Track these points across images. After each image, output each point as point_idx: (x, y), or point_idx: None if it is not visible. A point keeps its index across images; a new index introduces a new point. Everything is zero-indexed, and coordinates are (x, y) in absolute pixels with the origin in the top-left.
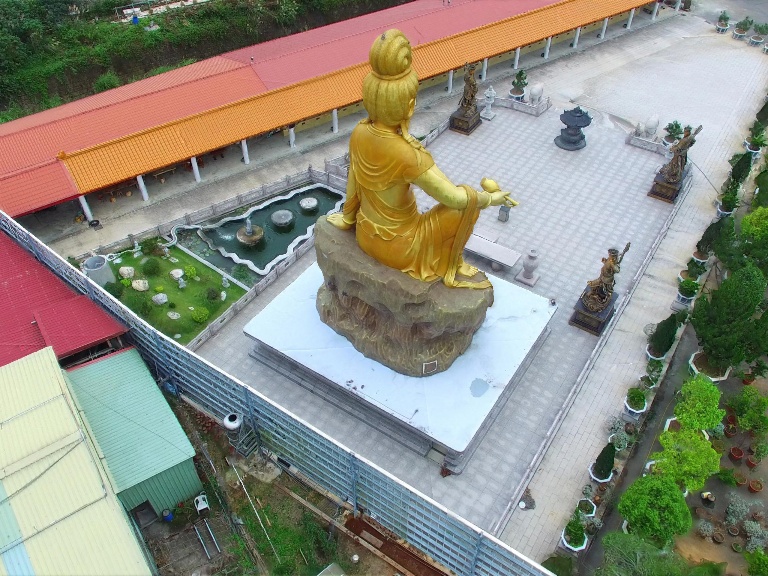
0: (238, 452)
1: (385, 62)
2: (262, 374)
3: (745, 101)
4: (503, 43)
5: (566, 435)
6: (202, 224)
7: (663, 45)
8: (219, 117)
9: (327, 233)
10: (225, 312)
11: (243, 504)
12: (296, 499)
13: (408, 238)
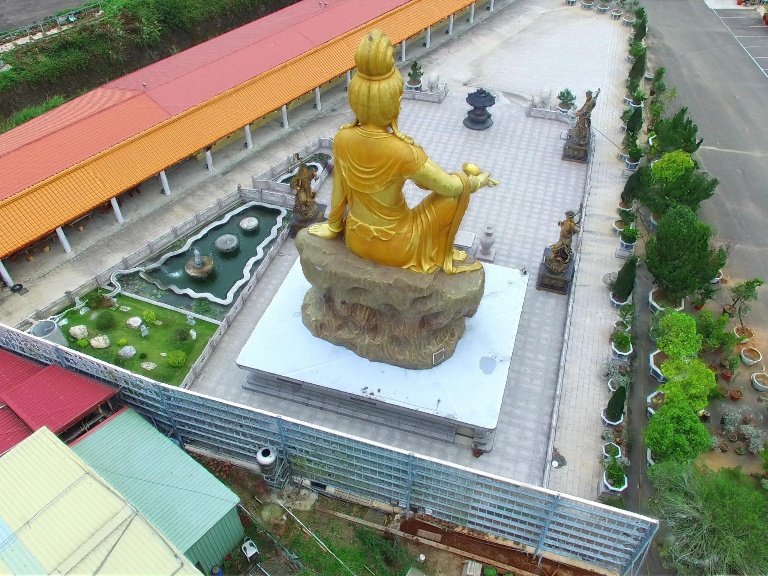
0: (270, 487)
1: (376, 63)
2: (264, 404)
3: (612, 63)
4: (390, 38)
5: (570, 391)
6: (141, 266)
7: (526, 22)
8: (132, 150)
9: (315, 245)
10: (204, 350)
11: (290, 538)
12: (343, 518)
13: (406, 234)
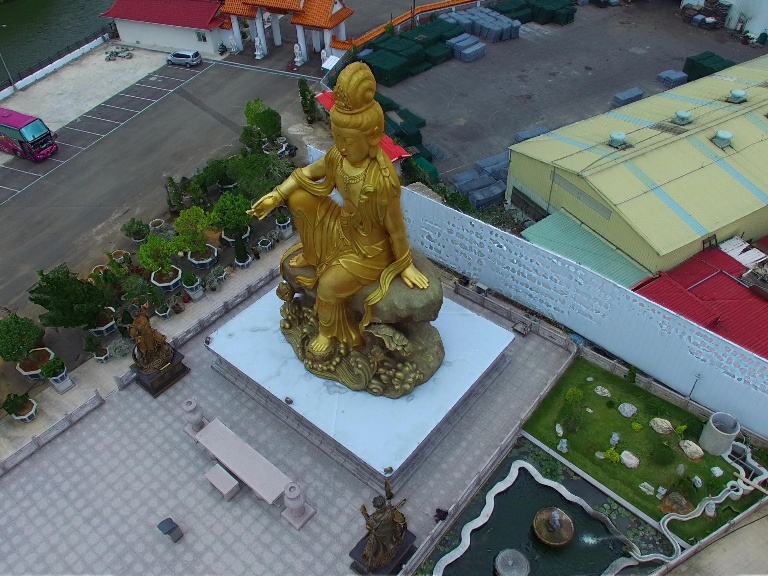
0: None
1: None
2: None
3: None
4: None
5: None
6: None
7: None
8: None
9: None
10: None
11: None
12: (454, 265)
13: None
